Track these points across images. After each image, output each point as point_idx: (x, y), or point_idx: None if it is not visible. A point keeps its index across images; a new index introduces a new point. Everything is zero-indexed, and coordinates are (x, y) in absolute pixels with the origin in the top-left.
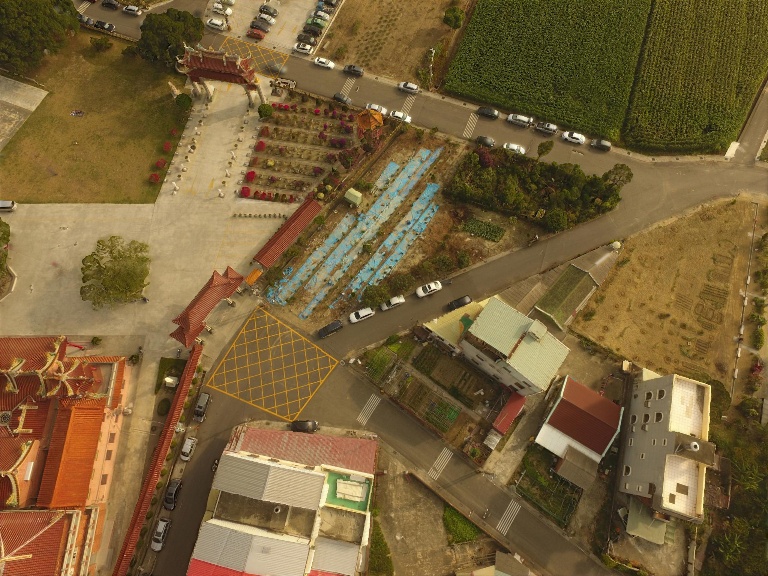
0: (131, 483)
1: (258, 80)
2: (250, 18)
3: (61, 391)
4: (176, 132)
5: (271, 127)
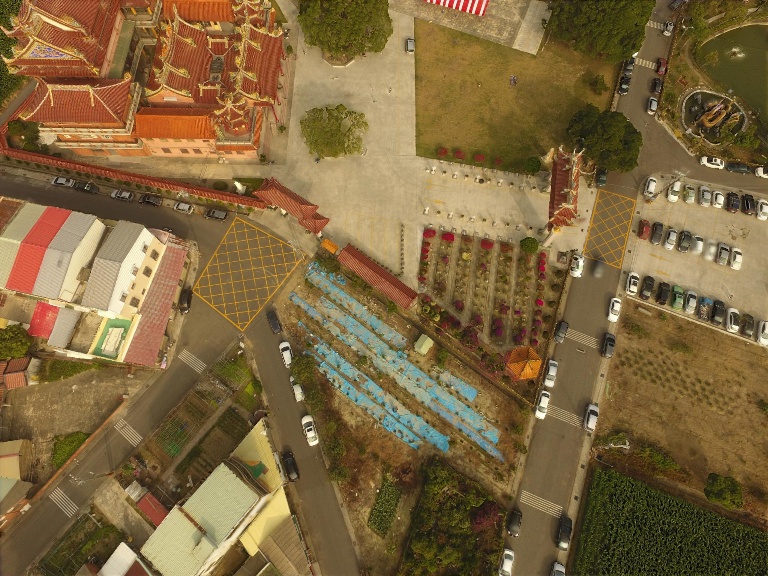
0: (165, 170)
1: (557, 231)
2: (670, 222)
3: (221, 107)
4: (498, 164)
5: (514, 254)
